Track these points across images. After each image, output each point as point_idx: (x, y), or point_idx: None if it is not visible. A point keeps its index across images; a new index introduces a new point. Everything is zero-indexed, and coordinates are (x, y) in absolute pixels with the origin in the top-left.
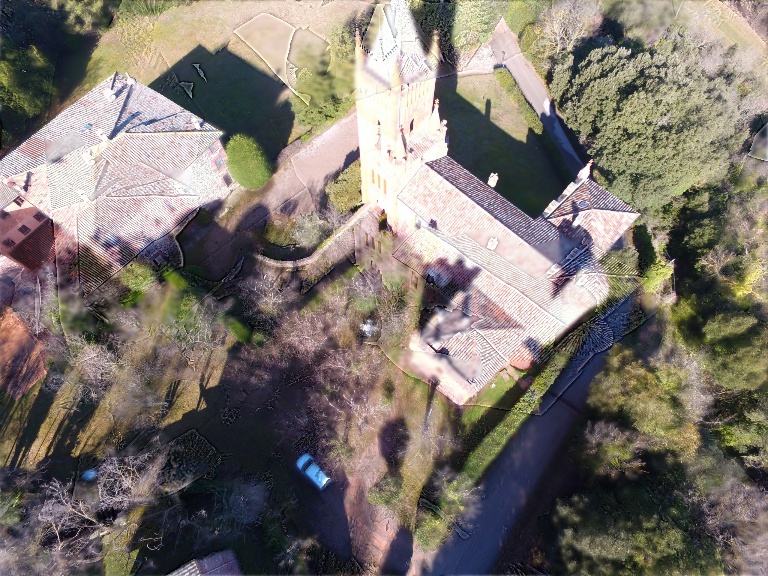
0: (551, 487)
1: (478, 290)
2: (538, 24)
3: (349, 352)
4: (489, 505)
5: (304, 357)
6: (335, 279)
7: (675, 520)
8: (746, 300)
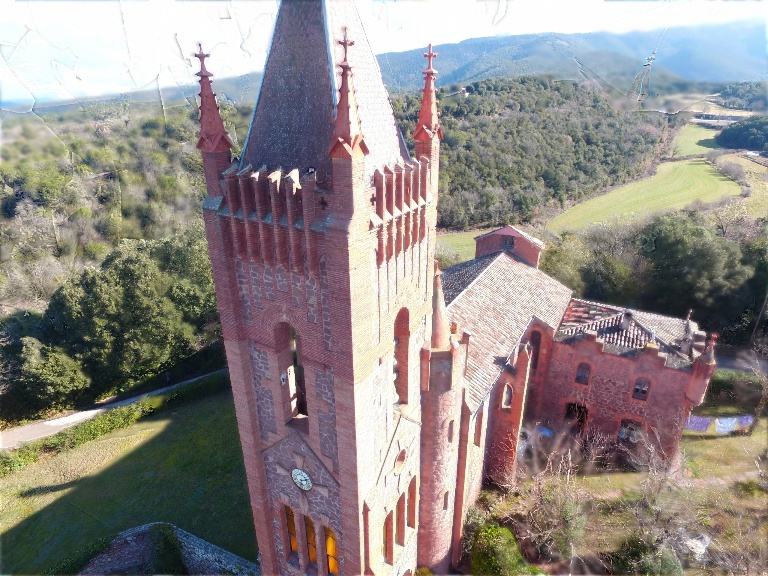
0: None
1: None
2: None
3: None
4: None
5: None
6: None
7: (644, 242)
8: None
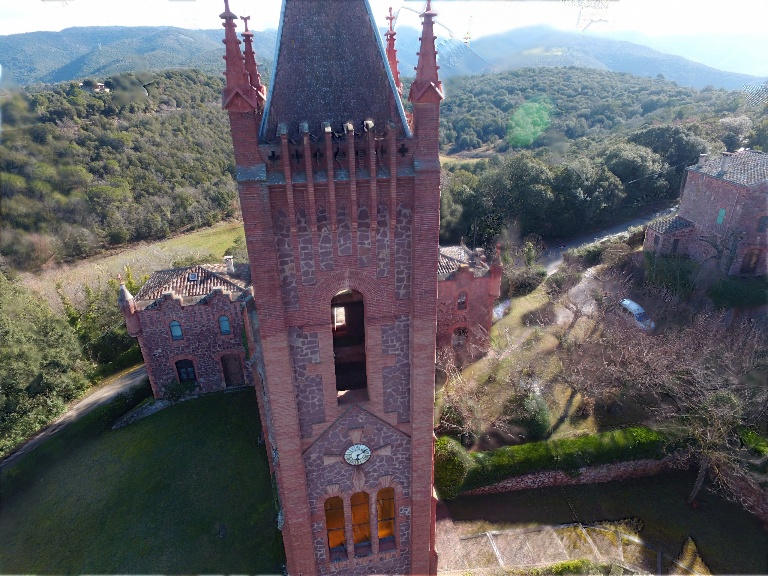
0: None
1: None
2: None
3: None
4: None
5: None
6: (563, 504)
7: None
8: None
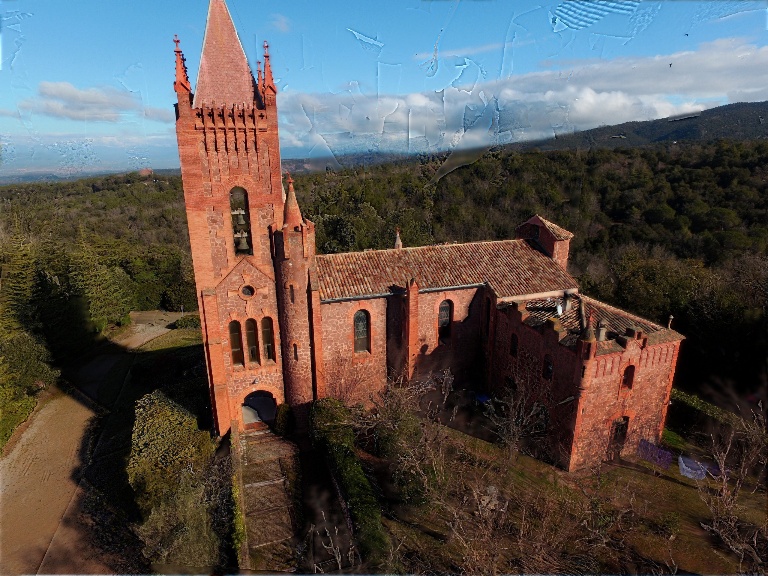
0: (767, 410)
1: None
2: (185, 272)
3: None
4: None
5: (595, 568)
6: None
7: None
8: None
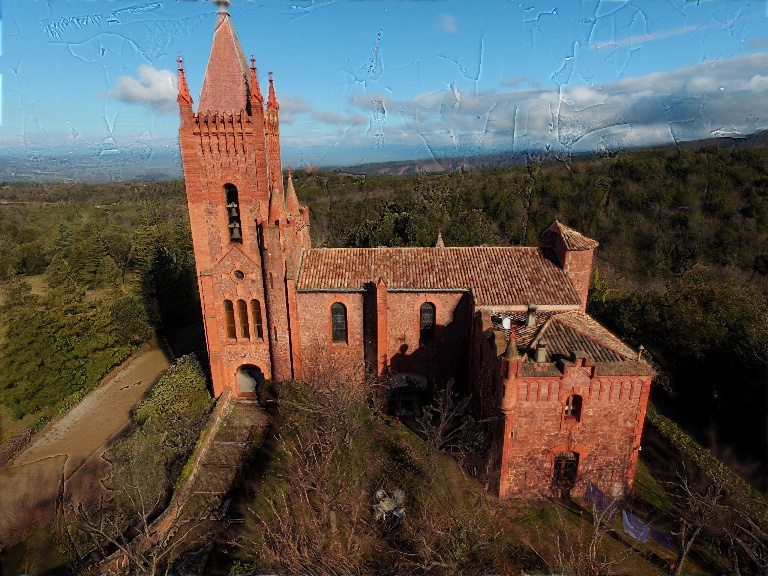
0: None
1: None
2: None
3: (400, 571)
4: None
5: (358, 574)
6: None
7: None
8: (611, 304)
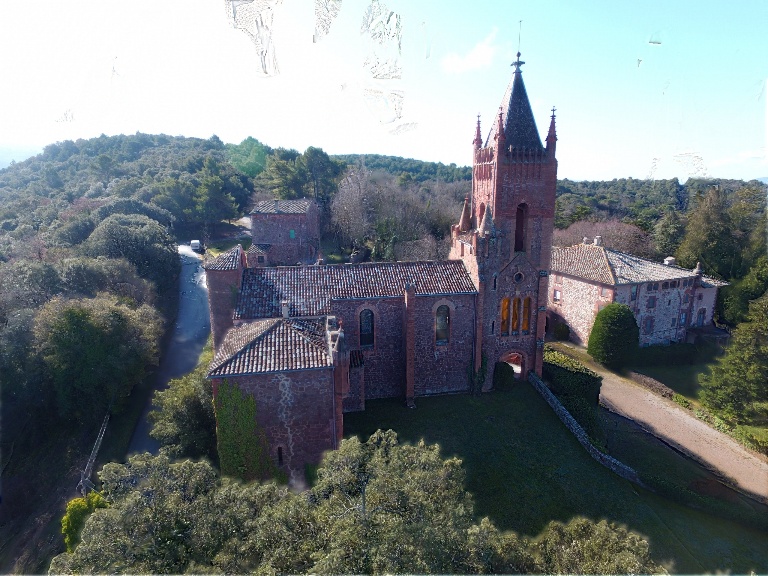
0: None
1: (258, 5)
2: None
3: None
4: (197, 327)
5: None
6: None
7: None
8: None
